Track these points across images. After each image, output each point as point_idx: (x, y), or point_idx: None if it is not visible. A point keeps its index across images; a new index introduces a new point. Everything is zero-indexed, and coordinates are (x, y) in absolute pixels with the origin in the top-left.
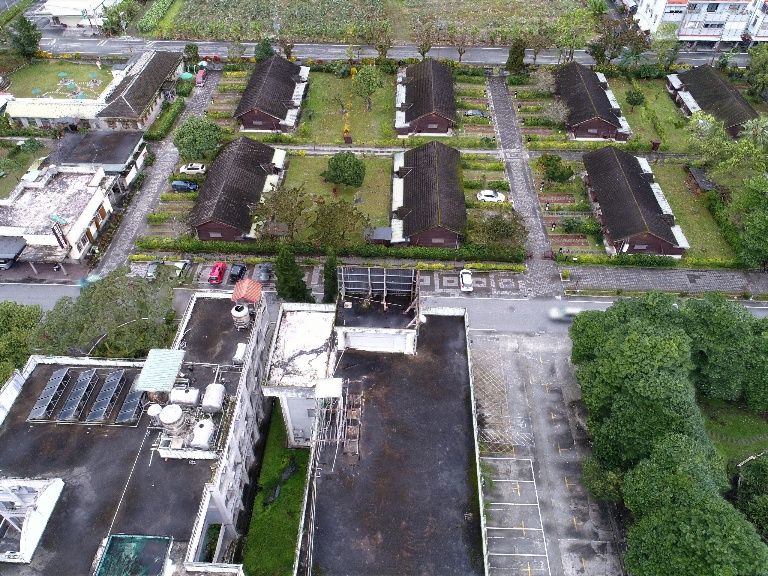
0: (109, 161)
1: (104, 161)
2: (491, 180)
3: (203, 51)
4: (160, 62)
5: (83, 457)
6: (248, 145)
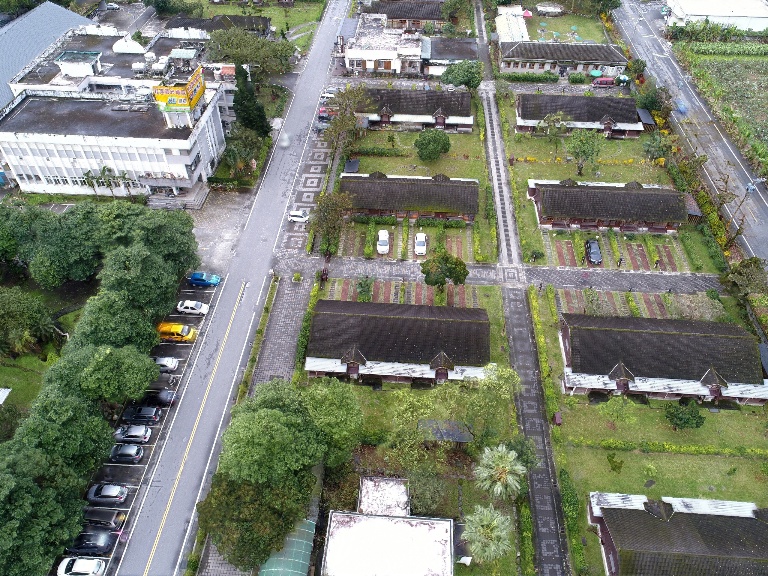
0: (436, 53)
1: (436, 52)
2: (456, 251)
3: (663, 79)
4: (594, 51)
5: (156, 55)
6: (460, 97)
